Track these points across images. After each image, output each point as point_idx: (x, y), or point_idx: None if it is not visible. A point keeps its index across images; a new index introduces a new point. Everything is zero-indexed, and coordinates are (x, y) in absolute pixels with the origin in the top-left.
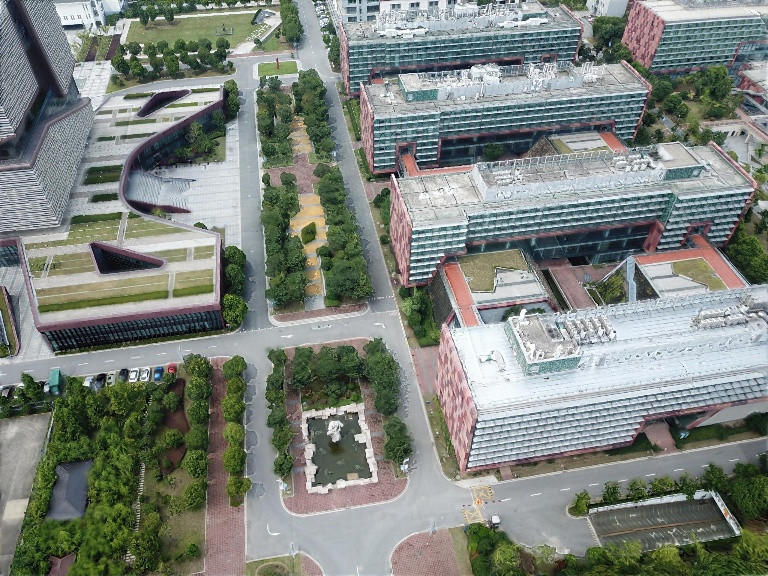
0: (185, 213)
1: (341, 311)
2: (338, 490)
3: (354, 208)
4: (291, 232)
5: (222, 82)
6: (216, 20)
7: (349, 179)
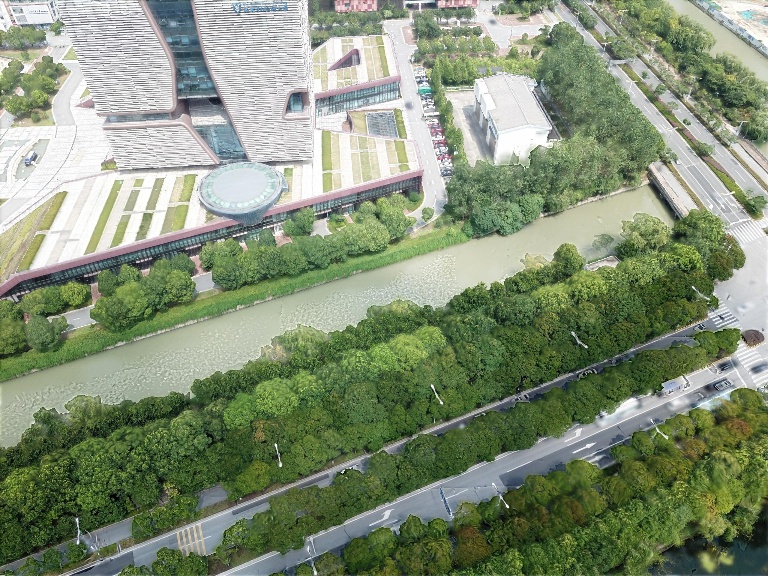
0: None
1: (383, 31)
2: None
3: None
4: None
5: None
6: None
7: None
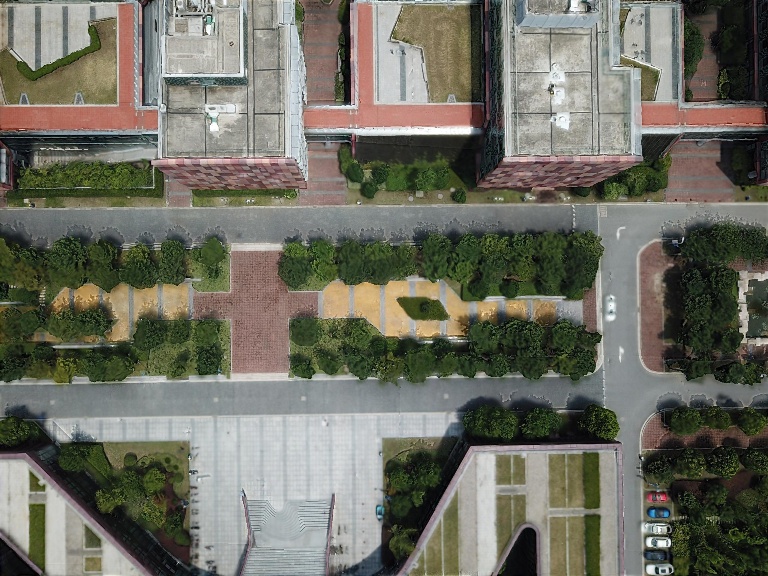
0: (335, 503)
1: None
2: None
3: (368, 231)
4: (415, 336)
5: None
6: None
7: (284, 228)
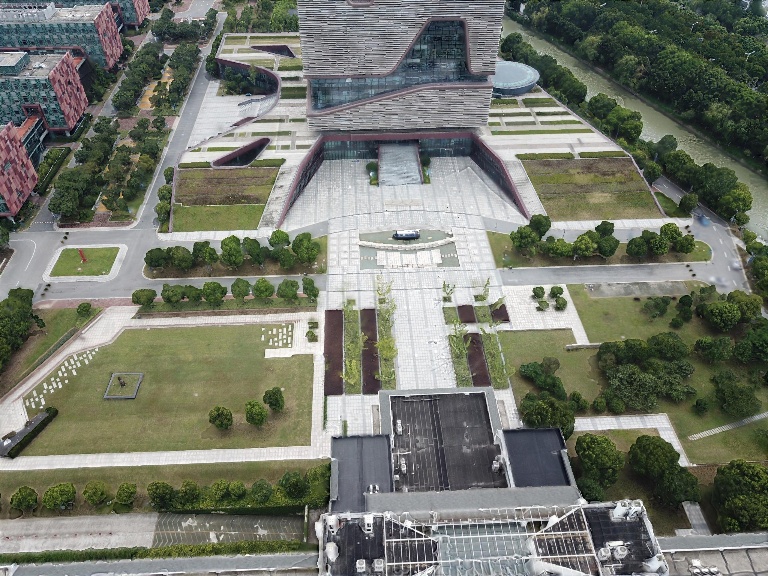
0: None
1: None
2: (197, 19)
3: None
4: None
5: (172, 244)
6: (125, 434)
7: None
